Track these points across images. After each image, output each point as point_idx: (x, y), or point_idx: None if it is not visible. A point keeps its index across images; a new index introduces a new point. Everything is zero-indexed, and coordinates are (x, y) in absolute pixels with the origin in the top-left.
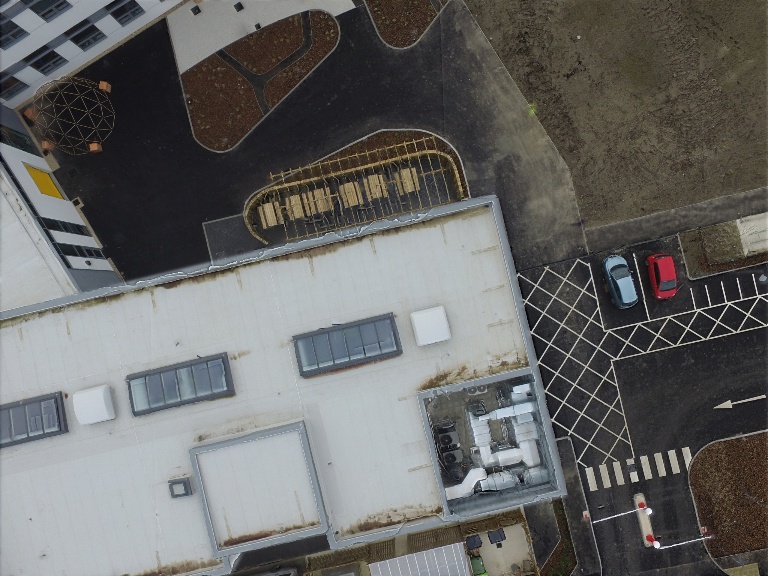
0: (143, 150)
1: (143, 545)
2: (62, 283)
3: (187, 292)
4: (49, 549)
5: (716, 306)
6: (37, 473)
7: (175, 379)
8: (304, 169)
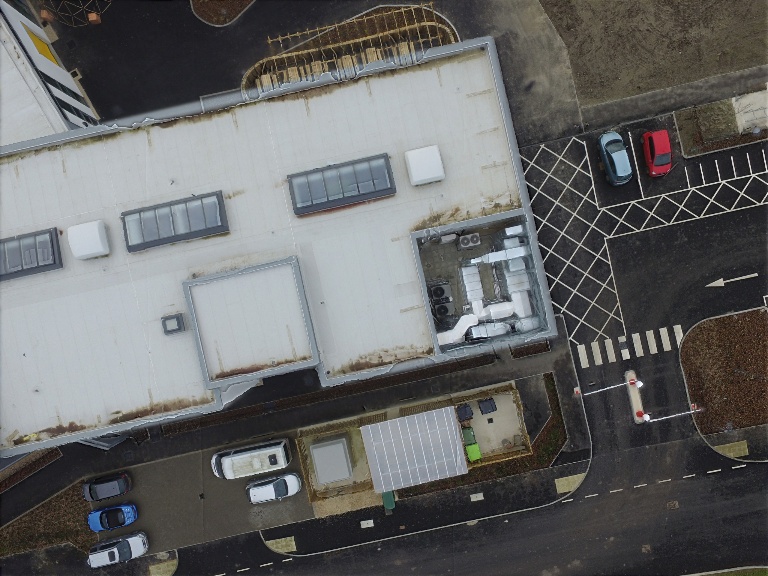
0: (142, 23)
1: (135, 382)
2: (59, 131)
3: (183, 132)
4: (42, 385)
5: (710, 185)
6: (31, 309)
7: (169, 215)
8: (302, 44)
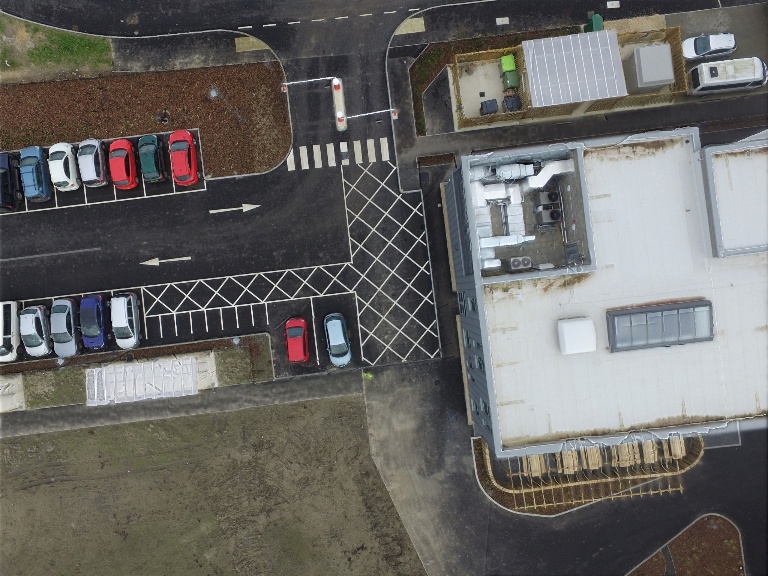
0: None
1: None
2: None
3: None
4: None
5: (246, 305)
6: None
7: None
8: (633, 487)
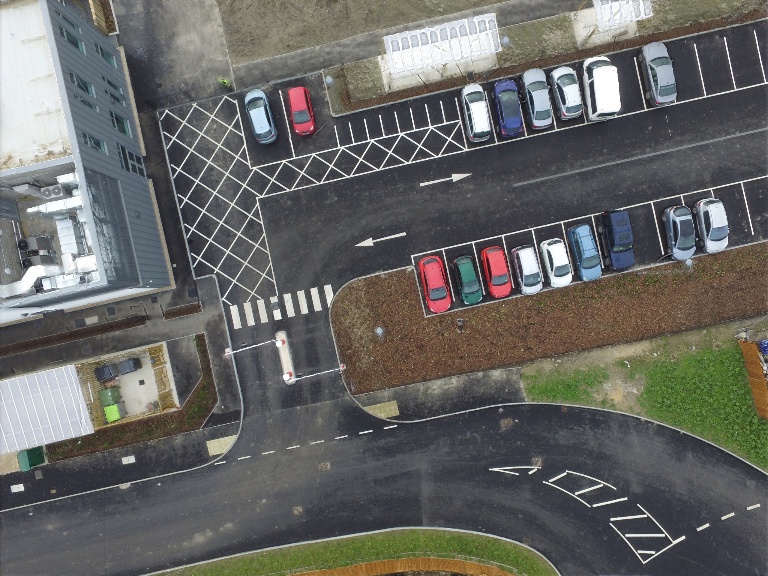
0: None
1: None
2: None
3: None
4: None
5: (359, 143)
6: None
7: None
8: None
